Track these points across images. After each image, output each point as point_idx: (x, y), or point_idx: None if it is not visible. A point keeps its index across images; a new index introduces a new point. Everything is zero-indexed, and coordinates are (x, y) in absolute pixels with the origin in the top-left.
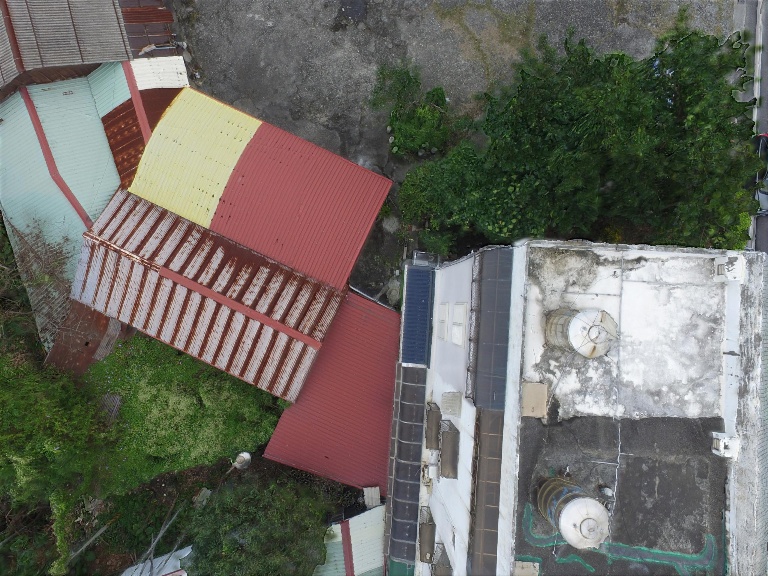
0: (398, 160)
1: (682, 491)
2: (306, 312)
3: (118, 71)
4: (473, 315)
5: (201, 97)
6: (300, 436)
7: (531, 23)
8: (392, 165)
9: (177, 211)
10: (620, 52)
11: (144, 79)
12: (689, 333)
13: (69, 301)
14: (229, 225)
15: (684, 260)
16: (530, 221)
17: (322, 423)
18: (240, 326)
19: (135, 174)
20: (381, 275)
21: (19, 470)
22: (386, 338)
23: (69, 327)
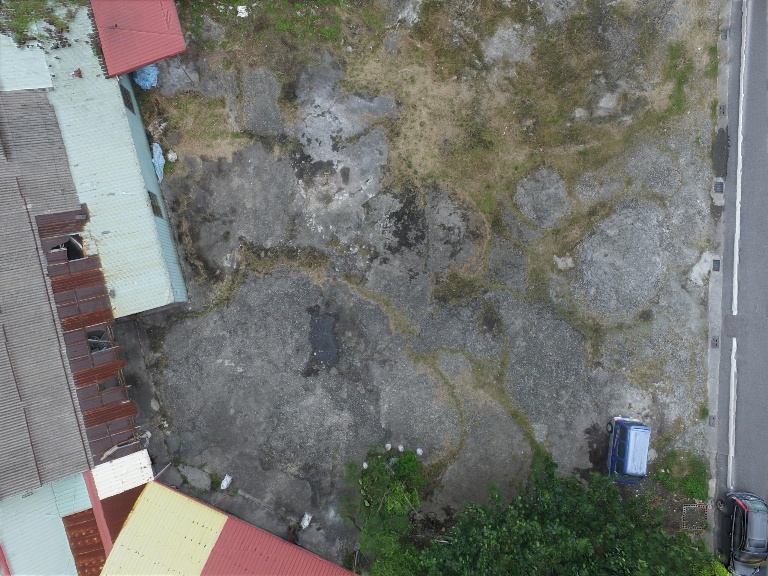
0: None
1: None
2: None
3: (79, 478)
4: None
5: (165, 492)
6: None
7: (505, 368)
8: (364, 516)
9: None
10: (595, 398)
11: (106, 486)
12: None
13: None
14: None
15: None
16: None
17: None
18: None
19: None
20: None
21: None
22: None
23: None
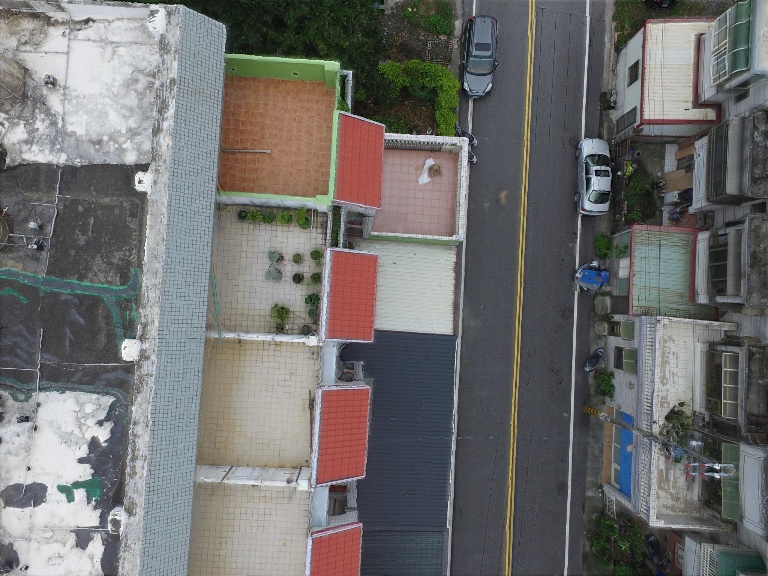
0: None
1: (114, 230)
2: None
3: None
4: None
5: None
6: None
7: None
8: None
9: None
10: None
11: None
12: (129, 87)
13: None
14: None
15: (129, 21)
16: None
17: None
18: None
19: None
20: None
21: None
22: None
23: None
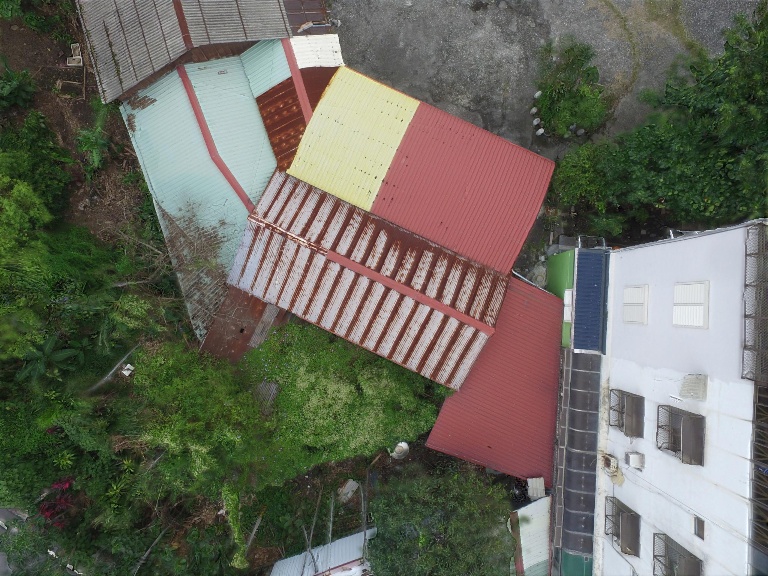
0: (542, 143)
1: None
2: (474, 297)
3: (277, 49)
4: (745, 292)
5: (357, 76)
6: (463, 425)
7: (678, 1)
8: (536, 148)
9: (337, 193)
10: None
11: (304, 57)
12: None
13: (222, 287)
14: (391, 208)
15: None
16: (740, 199)
17: (485, 412)
18: (408, 311)
19: (295, 155)
20: (526, 261)
21: (200, 459)
22: (548, 324)
23: (225, 313)
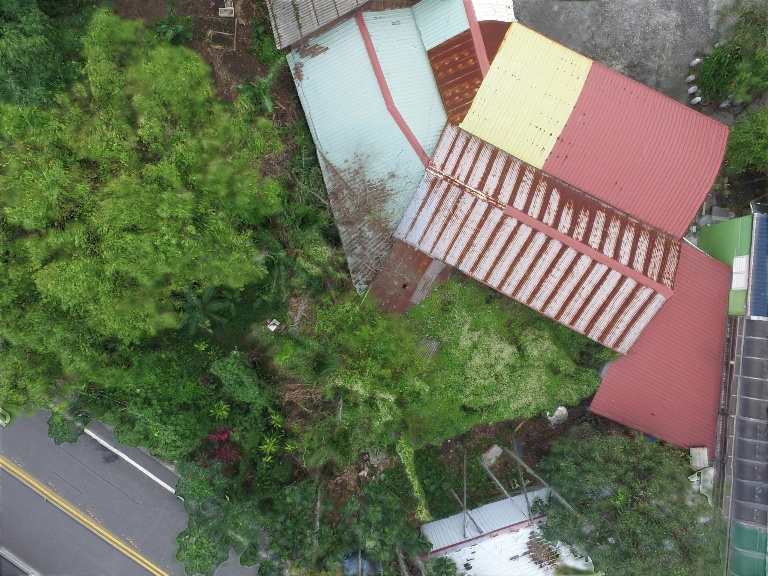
0: None
1: None
2: (650, 259)
3: (455, 1)
4: None
5: (530, 32)
6: (627, 391)
7: None
8: None
9: (509, 150)
10: None
11: (482, 10)
12: None
13: (384, 241)
14: (565, 166)
15: None
16: None
17: (649, 378)
18: (584, 271)
19: (469, 109)
20: None
21: (386, 408)
22: (715, 292)
23: (389, 268)
